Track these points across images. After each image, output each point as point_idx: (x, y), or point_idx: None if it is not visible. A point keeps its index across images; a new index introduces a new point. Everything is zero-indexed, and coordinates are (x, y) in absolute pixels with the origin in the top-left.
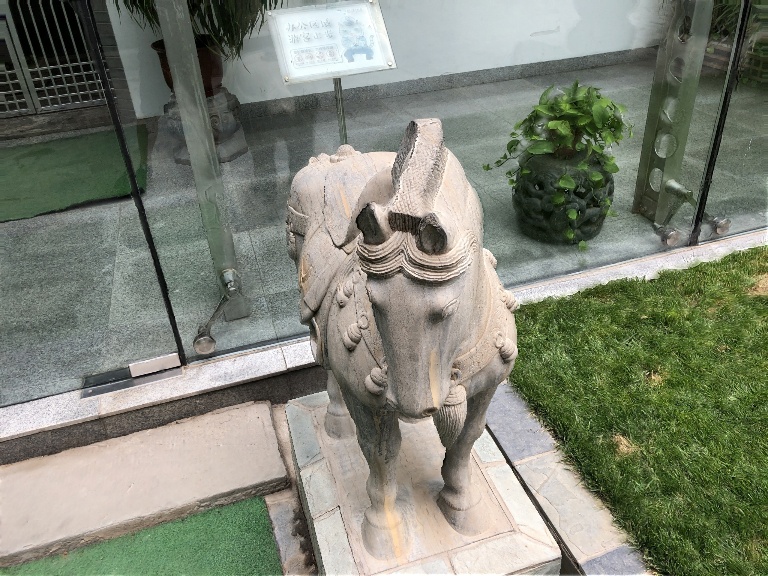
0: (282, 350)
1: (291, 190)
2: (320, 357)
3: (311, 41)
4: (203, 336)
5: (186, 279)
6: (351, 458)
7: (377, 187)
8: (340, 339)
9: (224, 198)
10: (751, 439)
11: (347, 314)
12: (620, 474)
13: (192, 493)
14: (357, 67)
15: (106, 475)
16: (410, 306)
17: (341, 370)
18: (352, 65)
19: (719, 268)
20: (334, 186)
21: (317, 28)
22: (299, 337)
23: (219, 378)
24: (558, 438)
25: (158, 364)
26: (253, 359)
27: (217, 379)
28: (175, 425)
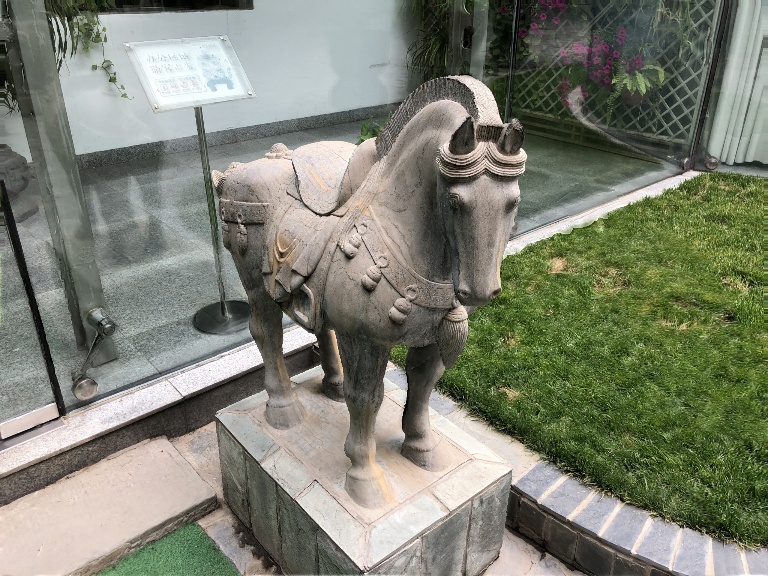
0: (170, 382)
1: (236, 186)
2: (313, 320)
3: (173, 72)
4: (84, 379)
5: (23, 337)
6: (307, 440)
7: (361, 156)
8: (355, 285)
9: (32, 256)
10: (592, 369)
11: (360, 262)
12: (517, 412)
13: (119, 536)
14: (221, 96)
15: (2, 547)
16: (492, 200)
17: (357, 314)
18: (216, 94)
19: (522, 258)
20: (304, 167)
21: (176, 60)
22: (183, 367)
23: (111, 419)
24: (457, 399)
25: (32, 419)
26: (141, 395)
27: (109, 421)
28: (67, 480)
